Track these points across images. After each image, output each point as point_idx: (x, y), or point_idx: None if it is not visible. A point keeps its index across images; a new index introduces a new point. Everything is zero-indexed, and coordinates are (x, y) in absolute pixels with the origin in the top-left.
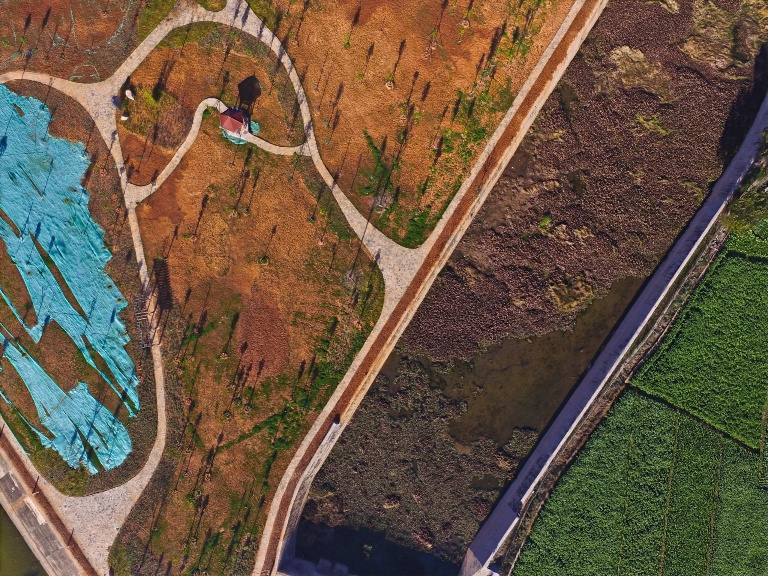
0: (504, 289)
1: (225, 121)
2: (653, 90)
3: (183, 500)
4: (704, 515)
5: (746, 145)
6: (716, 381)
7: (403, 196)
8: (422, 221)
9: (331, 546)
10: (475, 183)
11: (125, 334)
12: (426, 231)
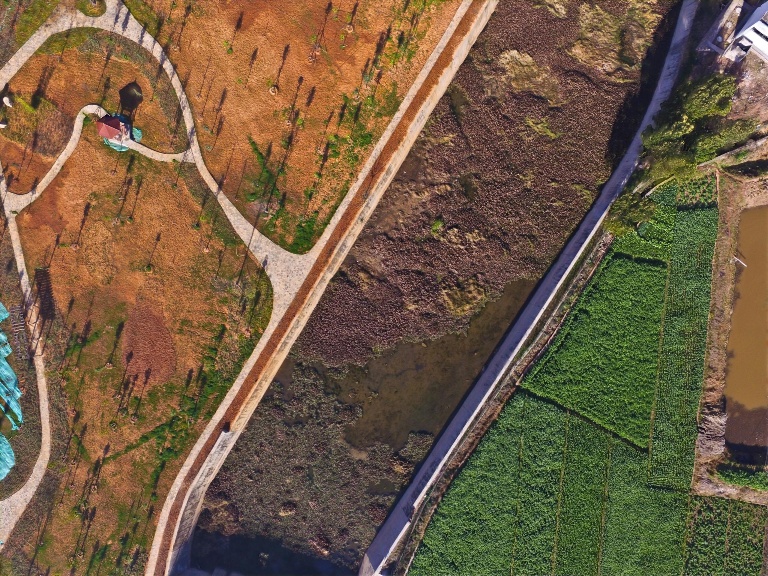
0: (397, 293)
1: (101, 128)
2: (542, 94)
3: (69, 513)
4: (595, 515)
5: (633, 147)
6: (604, 382)
7: (290, 202)
8: (309, 227)
9: (227, 555)
10: (362, 188)
11: (2, 346)
12: (314, 237)
